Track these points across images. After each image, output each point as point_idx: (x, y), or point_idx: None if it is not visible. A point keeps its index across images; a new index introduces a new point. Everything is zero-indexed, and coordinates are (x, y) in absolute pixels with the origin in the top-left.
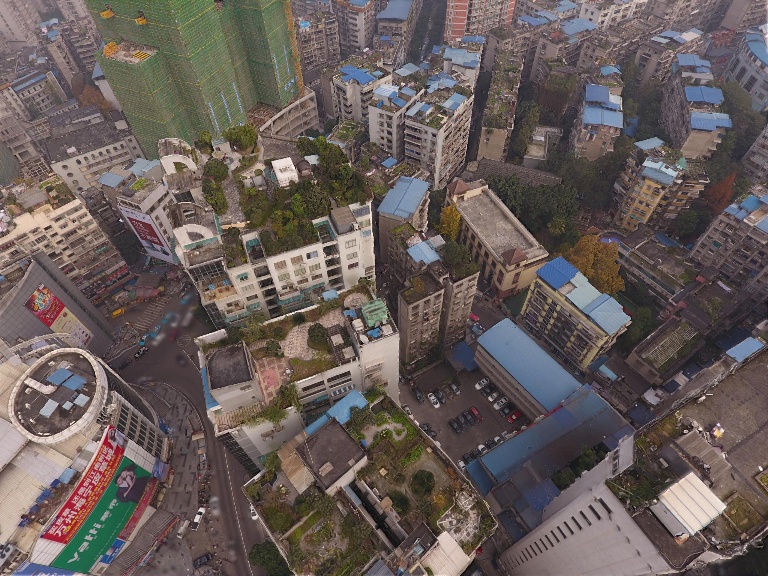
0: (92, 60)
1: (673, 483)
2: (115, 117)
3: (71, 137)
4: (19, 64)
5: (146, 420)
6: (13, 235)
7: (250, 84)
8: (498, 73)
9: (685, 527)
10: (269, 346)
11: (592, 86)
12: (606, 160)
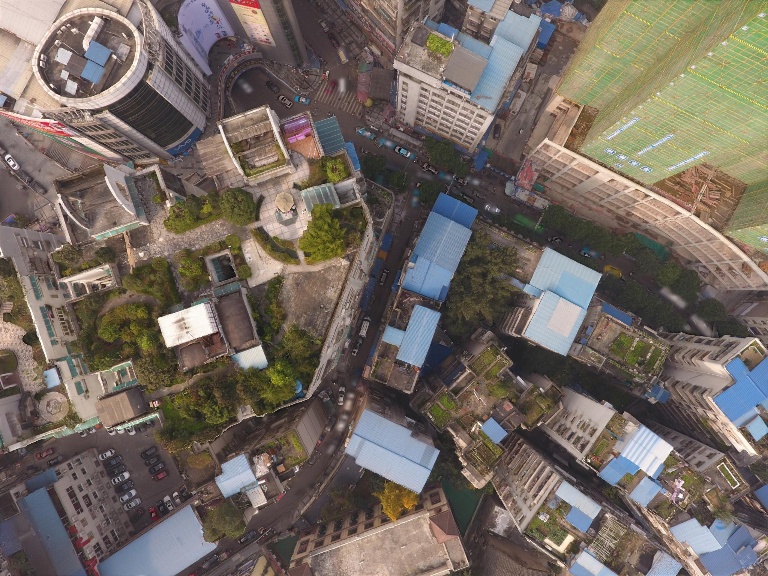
0: None
1: None
2: None
3: None
4: None
5: (146, 141)
6: None
7: None
8: None
9: None
10: None
11: None
12: None
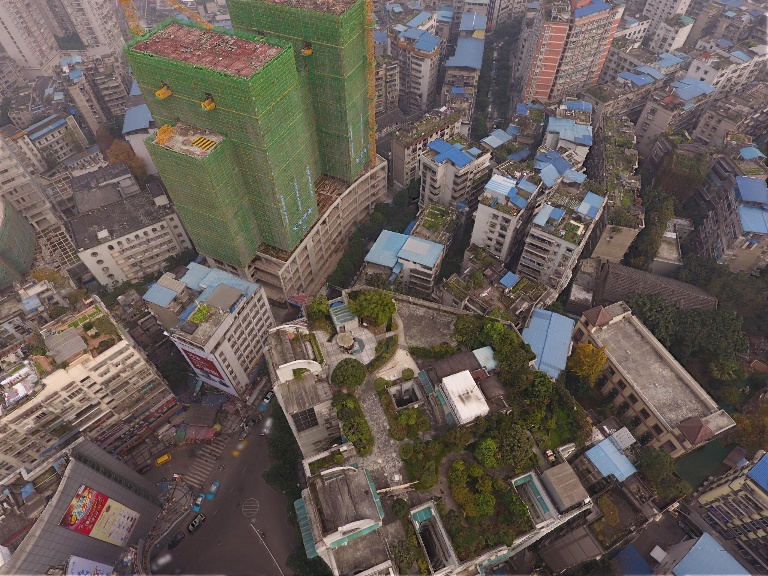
0: (118, 102)
1: None
2: (154, 191)
3: (101, 214)
4: (34, 100)
5: None
6: (40, 397)
7: (316, 155)
8: (609, 148)
9: None
10: None
11: (744, 179)
12: None
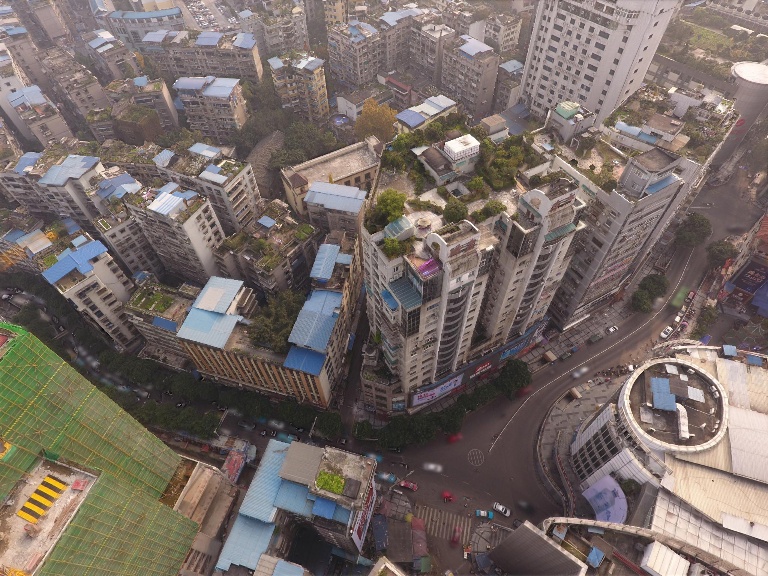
0: None
1: None
2: None
3: None
4: None
5: None
6: None
7: None
8: None
9: None
10: None
11: (177, 84)
12: (270, 98)
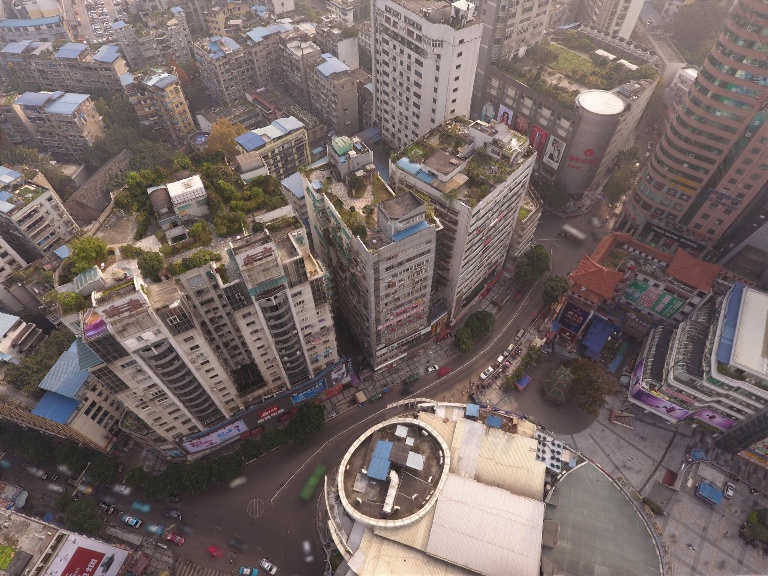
0: None
1: (457, 8)
2: None
3: None
4: None
5: None
6: None
7: None
8: None
9: (474, 6)
10: (370, 208)
11: (19, 100)
12: (121, 115)
